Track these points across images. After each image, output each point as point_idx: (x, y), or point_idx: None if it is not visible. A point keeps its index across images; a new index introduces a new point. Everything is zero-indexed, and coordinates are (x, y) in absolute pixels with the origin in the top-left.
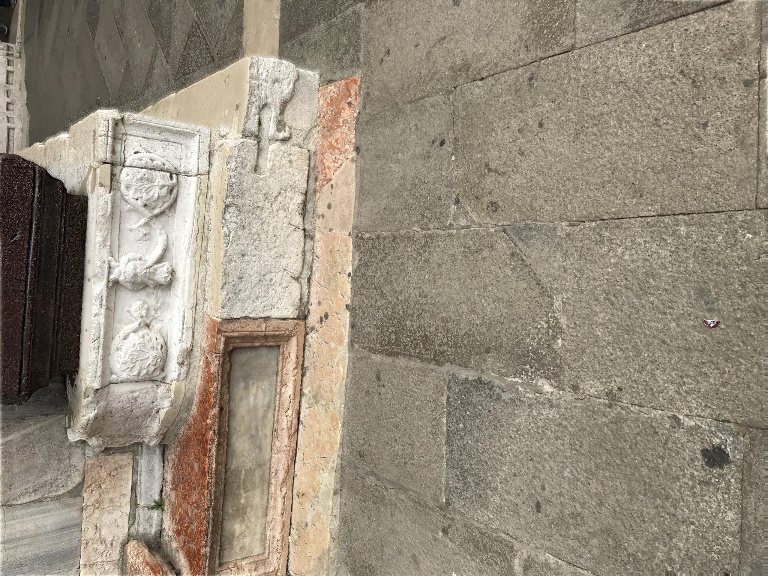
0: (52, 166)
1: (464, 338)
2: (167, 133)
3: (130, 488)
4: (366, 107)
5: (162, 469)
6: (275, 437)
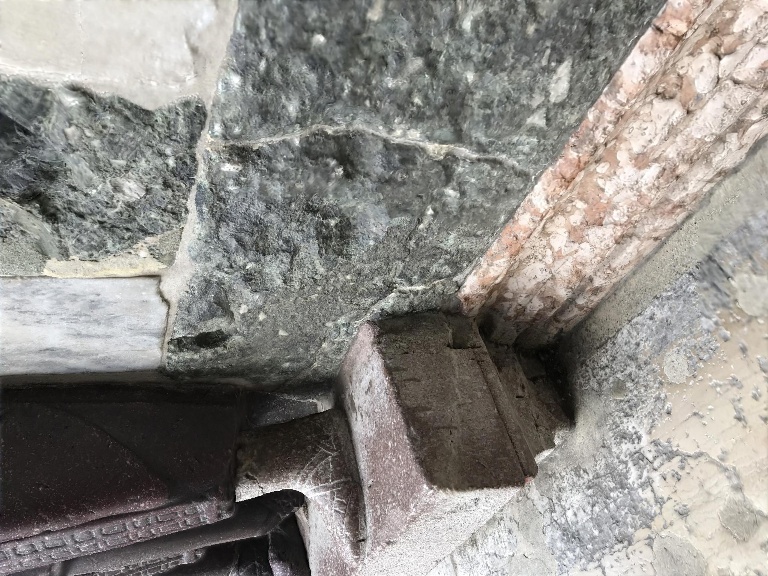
0: None
1: None
2: None
3: None
4: None
5: None
6: None
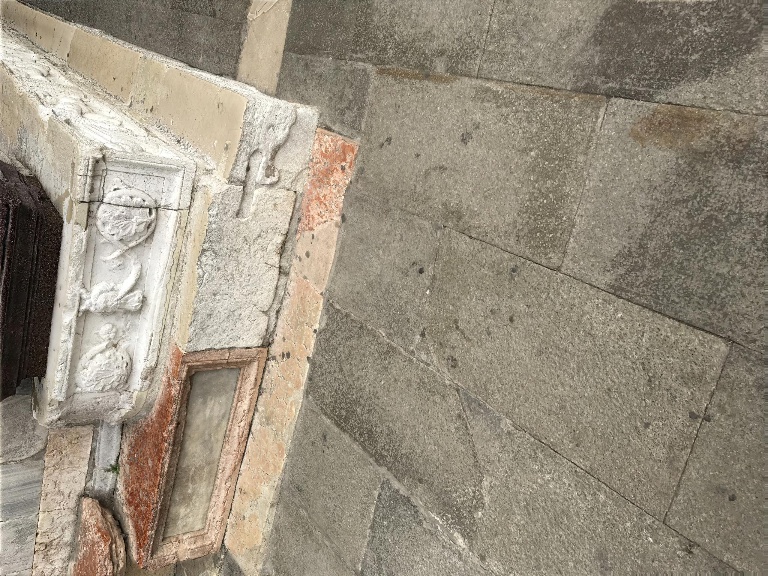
0: (29, 133)
1: (403, 456)
2: (150, 168)
3: (89, 453)
4: (358, 181)
5: (120, 440)
6: (226, 442)
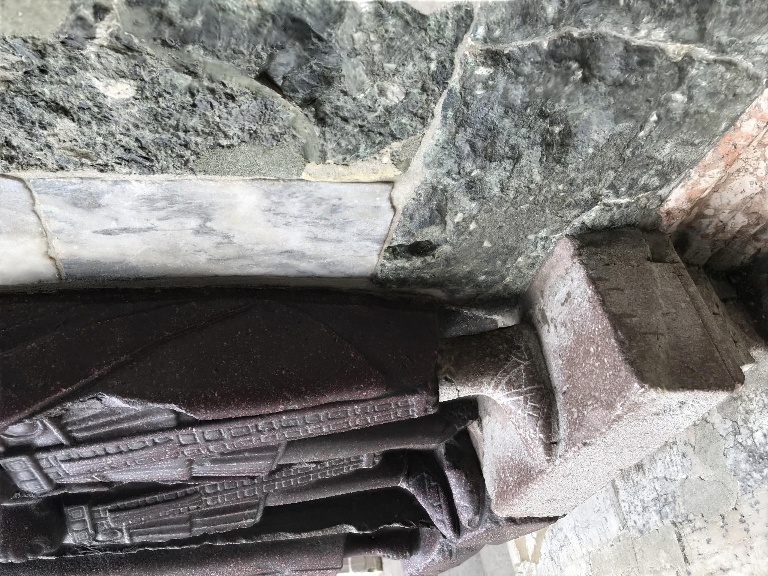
0: (741, 501)
1: None
2: None
3: None
4: None
5: None
6: None
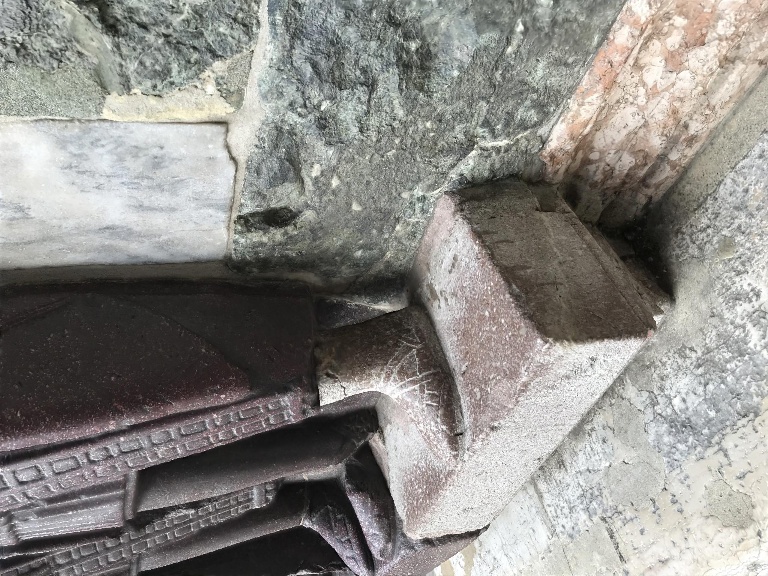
0: (670, 479)
1: None
2: None
3: None
4: None
5: None
6: None
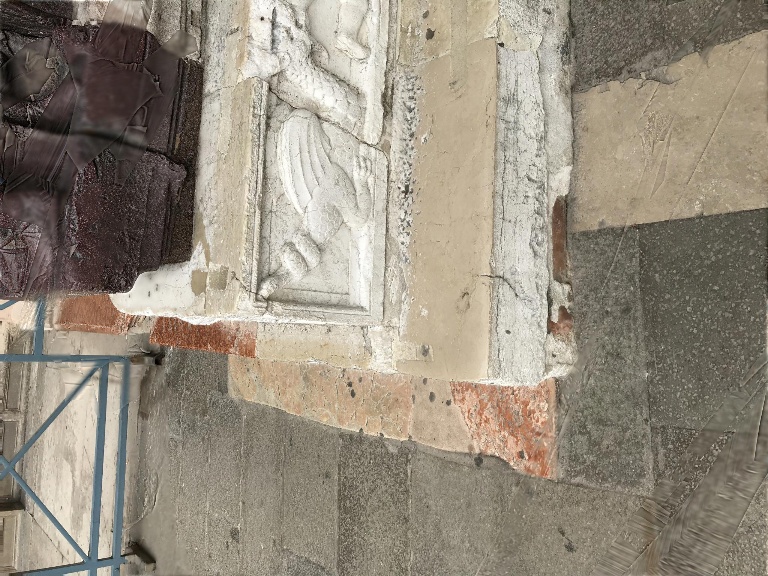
0: None
1: None
2: None
3: None
4: None
5: None
6: None
